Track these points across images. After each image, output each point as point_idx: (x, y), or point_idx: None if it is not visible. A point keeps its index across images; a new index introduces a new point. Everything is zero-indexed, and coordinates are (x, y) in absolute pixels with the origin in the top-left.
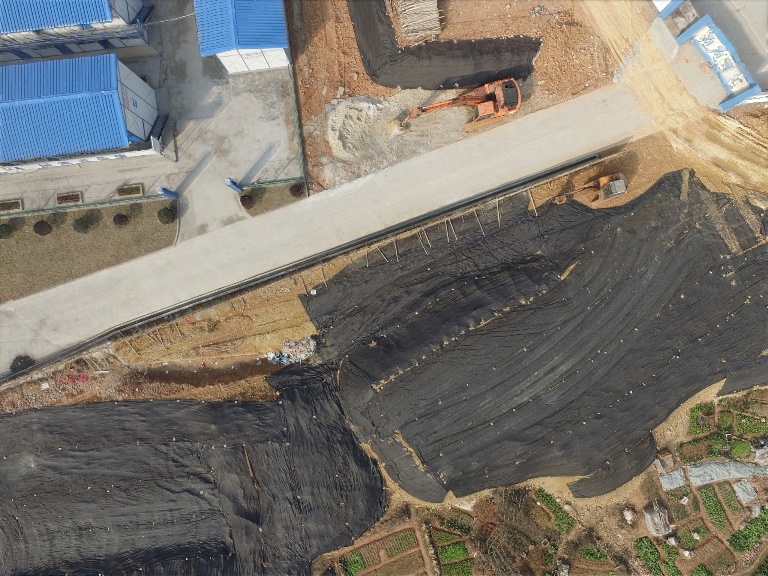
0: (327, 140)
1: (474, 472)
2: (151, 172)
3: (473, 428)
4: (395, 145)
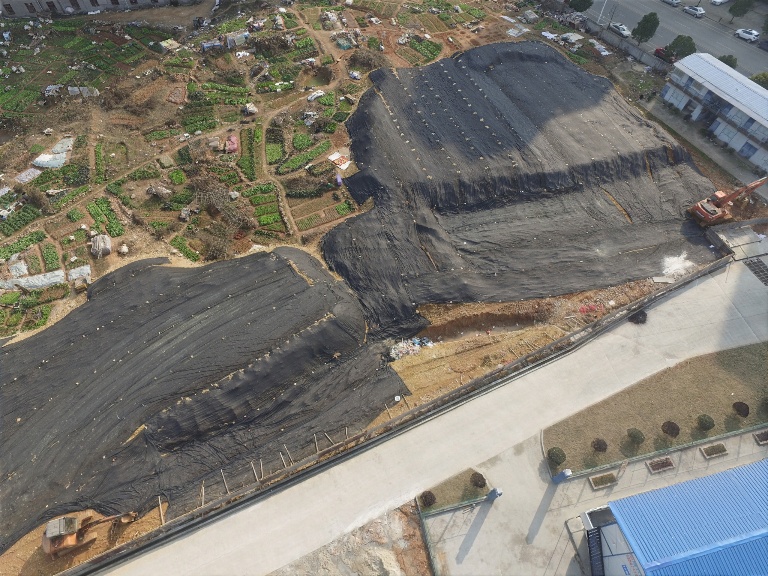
0: (403, 572)
1: (248, 263)
2: (589, 506)
3: (246, 292)
4: (321, 574)
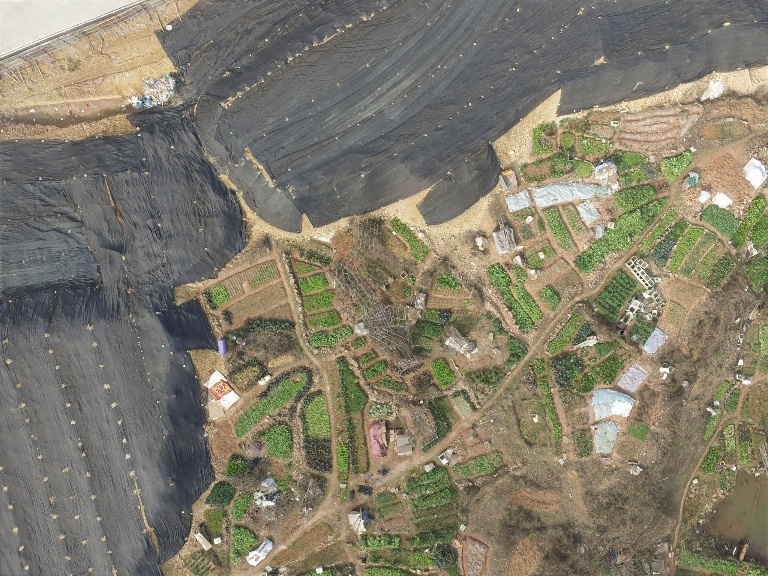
0: None
1: (322, 188)
2: None
3: (319, 143)
4: None
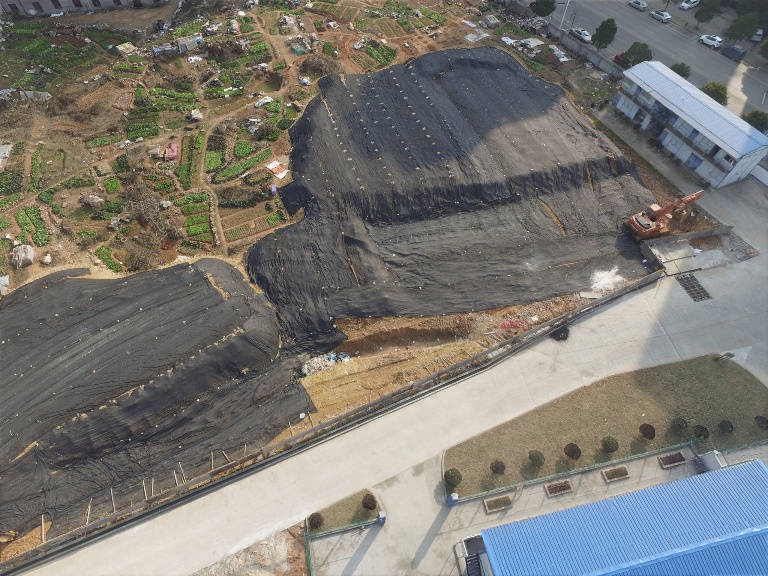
0: None
1: (165, 275)
2: (480, 530)
3: (159, 305)
4: None
